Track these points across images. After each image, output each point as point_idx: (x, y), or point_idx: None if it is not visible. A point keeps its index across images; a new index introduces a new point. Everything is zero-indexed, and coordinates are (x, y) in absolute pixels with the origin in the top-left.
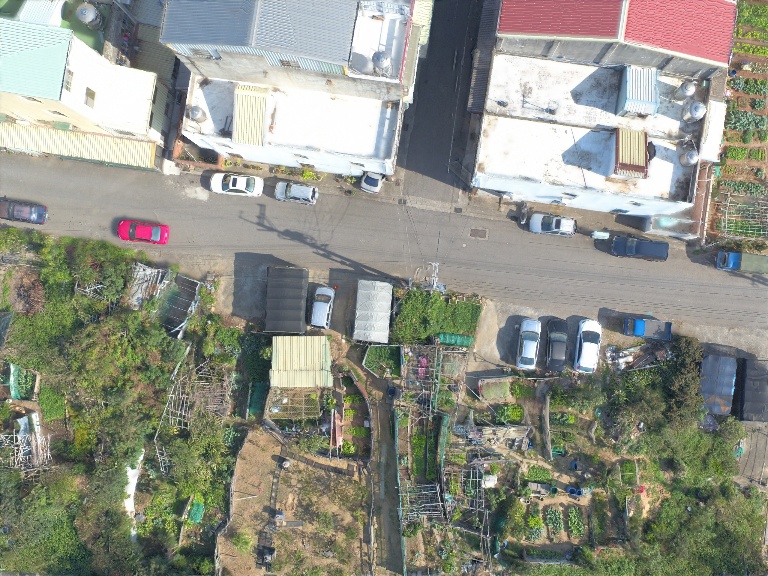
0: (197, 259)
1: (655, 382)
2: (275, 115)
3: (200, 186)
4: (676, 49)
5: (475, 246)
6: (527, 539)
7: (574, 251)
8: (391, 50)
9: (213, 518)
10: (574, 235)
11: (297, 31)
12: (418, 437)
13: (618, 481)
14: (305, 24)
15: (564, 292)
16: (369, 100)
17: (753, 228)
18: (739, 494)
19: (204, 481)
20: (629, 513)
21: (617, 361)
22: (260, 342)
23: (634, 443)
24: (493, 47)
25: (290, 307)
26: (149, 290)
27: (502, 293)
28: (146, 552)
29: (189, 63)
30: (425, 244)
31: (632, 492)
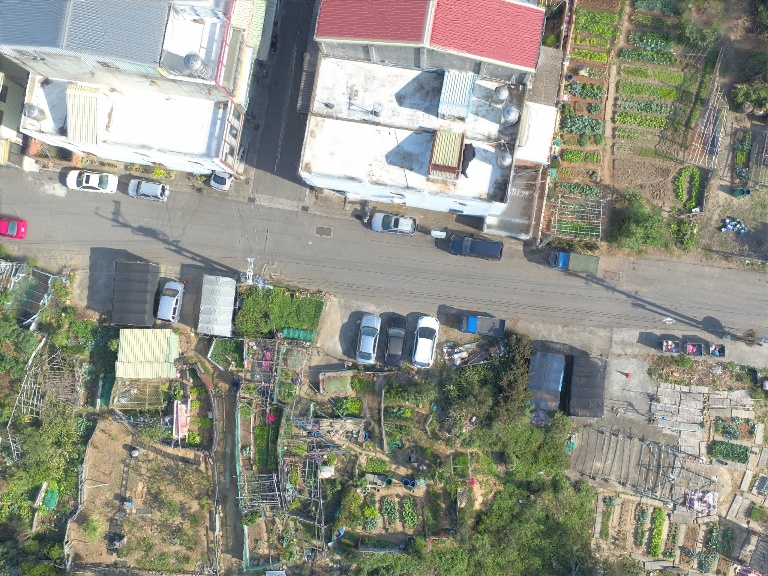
0: (54, 253)
1: (487, 377)
2: (112, 114)
3: (58, 183)
4: (483, 54)
5: (320, 244)
6: (364, 529)
7: (415, 249)
8: (211, 53)
9: (66, 505)
10: (415, 234)
11: (108, 34)
12: (260, 428)
13: (447, 473)
14: (116, 27)
15: (405, 289)
16: (202, 101)
17: (582, 229)
18: (570, 488)
19: (57, 469)
20: (461, 504)
21: (453, 357)
22: (112, 334)
23: (467, 436)
24: (319, 51)
25: (136, 300)
26: (3, 283)
27: (346, 289)
28: (2, 537)
29: (22, 63)
30: (272, 241)
31: (465, 484)
